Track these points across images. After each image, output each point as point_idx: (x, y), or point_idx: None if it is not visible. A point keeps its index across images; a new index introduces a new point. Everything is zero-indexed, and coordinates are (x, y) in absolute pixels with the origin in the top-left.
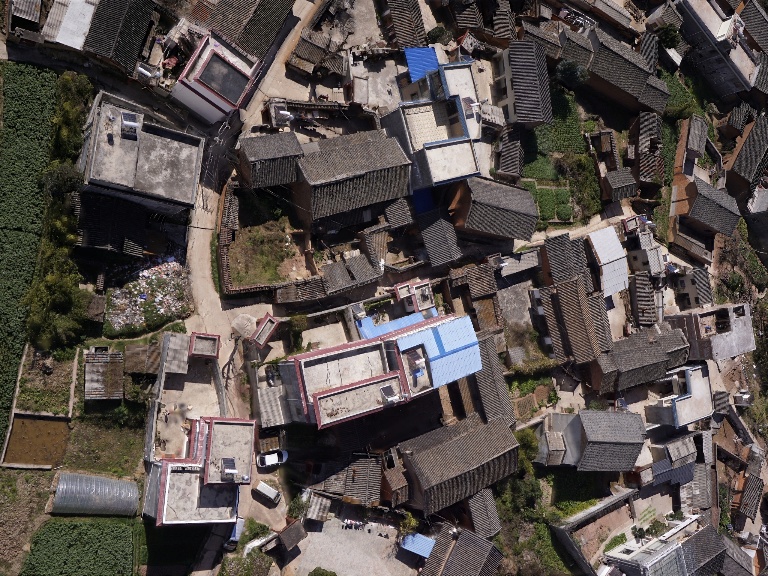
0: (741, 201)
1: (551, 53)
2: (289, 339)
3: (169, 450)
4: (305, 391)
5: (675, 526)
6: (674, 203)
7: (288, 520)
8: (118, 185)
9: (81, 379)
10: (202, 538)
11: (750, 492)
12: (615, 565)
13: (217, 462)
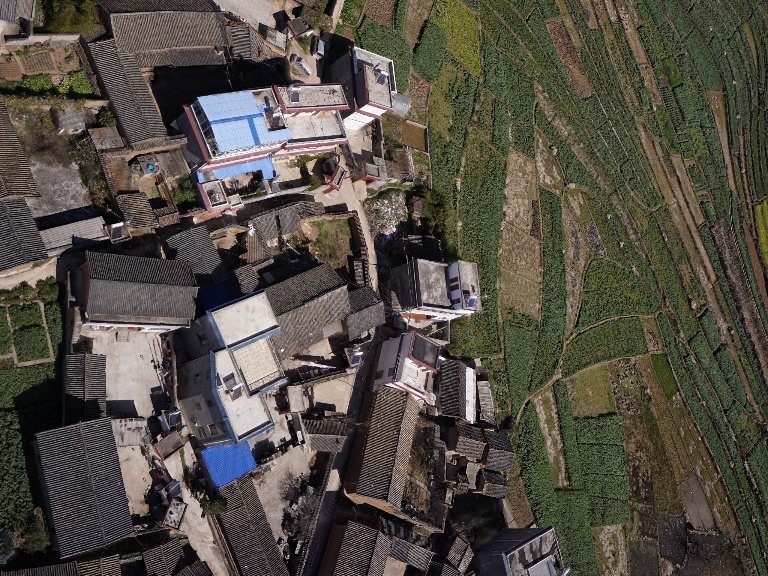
0: None
1: None
2: None
3: None
4: None
5: None
6: None
7: None
8: None
9: None
10: None
11: None
12: None
13: (384, 84)
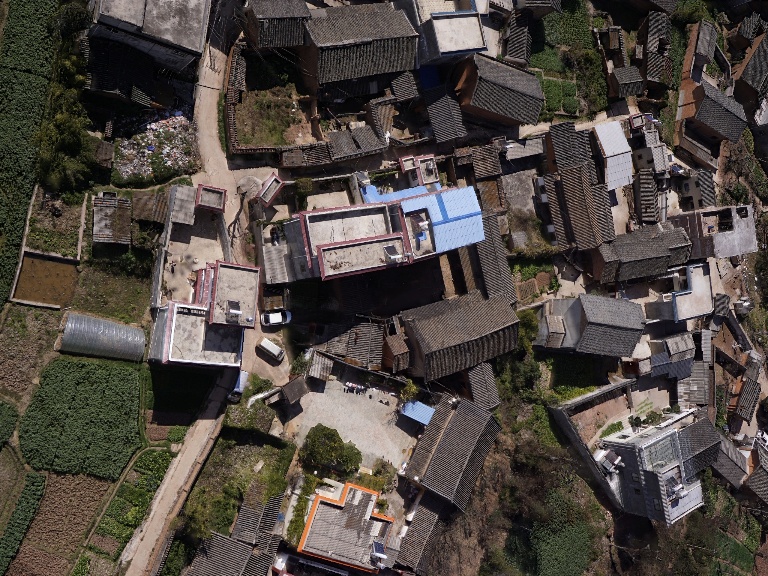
0: (748, 113)
1: None
2: (294, 204)
3: (175, 300)
4: (309, 245)
5: (671, 418)
6: (681, 107)
7: (291, 378)
8: (127, 25)
9: (89, 223)
10: (207, 389)
11: (747, 395)
12: (611, 449)
13: (222, 304)
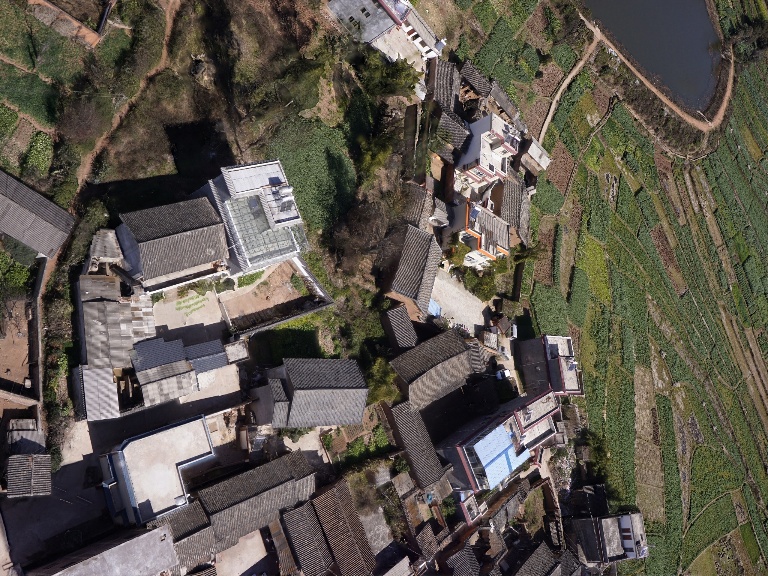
0: None
1: None
2: None
3: None
4: None
5: None
6: None
7: None
8: None
9: None
10: None
11: None
12: None
13: None
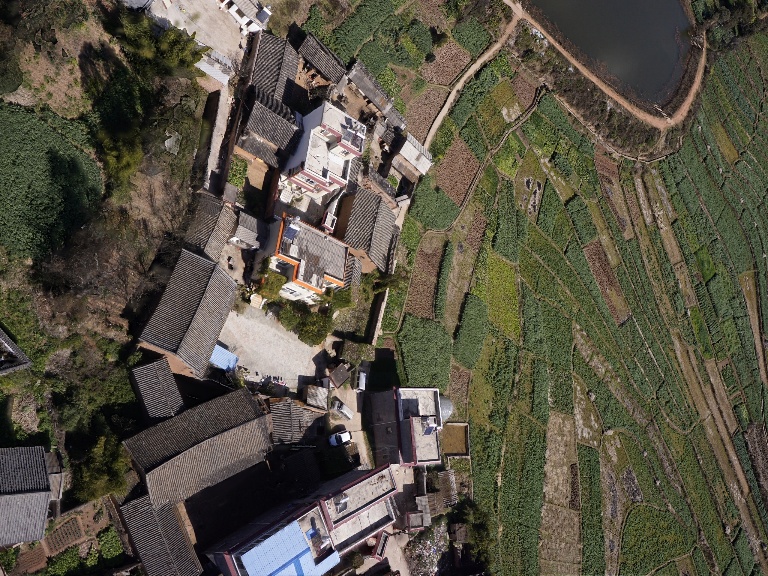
0: None
1: None
2: None
3: None
4: None
5: None
6: None
7: None
8: None
9: None
10: None
11: None
12: None
13: (431, 432)
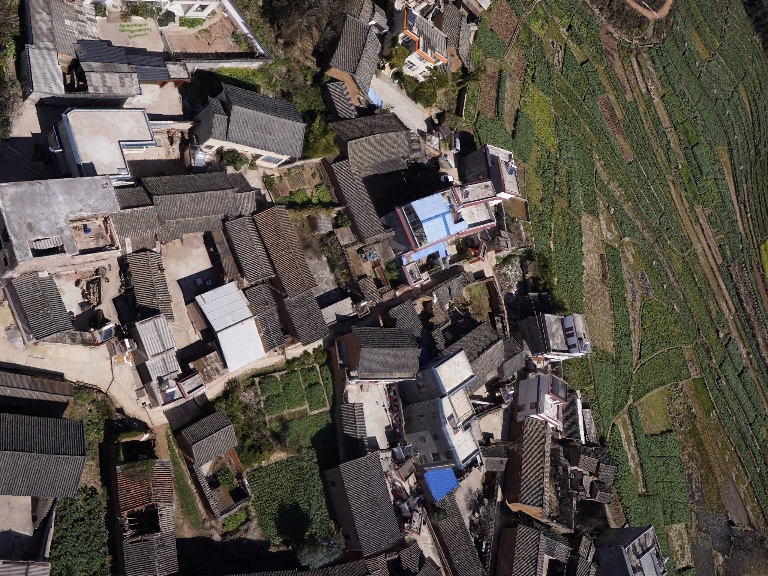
0: None
1: (331, 572)
2: None
3: None
4: None
5: None
6: None
7: None
8: None
9: None
10: None
11: None
12: None
13: None
